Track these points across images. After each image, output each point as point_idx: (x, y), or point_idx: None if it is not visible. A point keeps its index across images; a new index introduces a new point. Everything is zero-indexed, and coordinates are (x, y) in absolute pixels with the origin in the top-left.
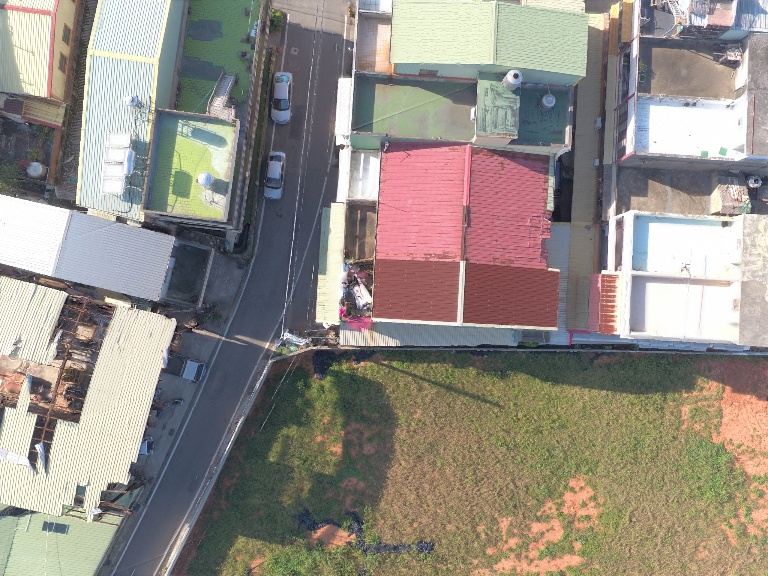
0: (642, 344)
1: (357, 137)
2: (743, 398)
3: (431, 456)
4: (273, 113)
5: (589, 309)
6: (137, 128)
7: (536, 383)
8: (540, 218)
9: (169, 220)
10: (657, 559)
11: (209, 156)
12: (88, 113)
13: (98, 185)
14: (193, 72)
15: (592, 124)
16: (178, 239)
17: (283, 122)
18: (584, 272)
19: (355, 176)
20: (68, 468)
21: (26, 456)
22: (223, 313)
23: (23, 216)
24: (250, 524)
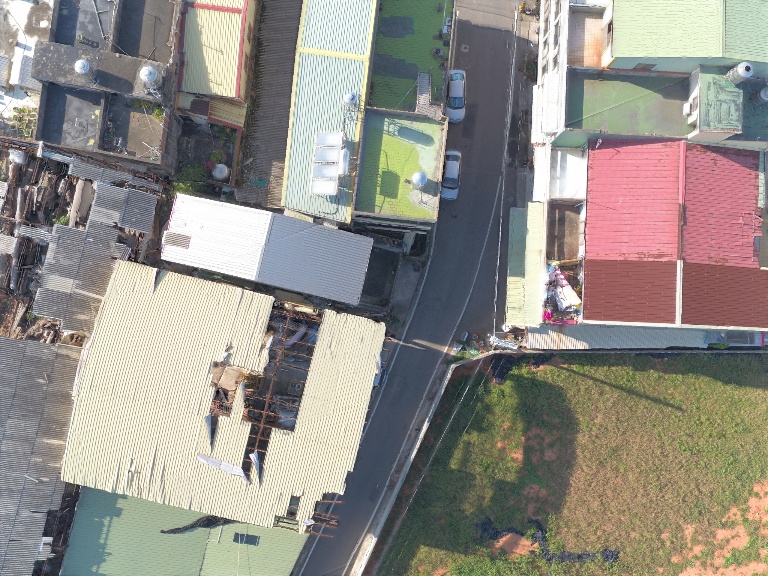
0: None
1: (567, 134)
2: None
3: (614, 462)
4: (447, 112)
5: None
6: (345, 127)
7: (718, 386)
8: (752, 215)
9: None
10: None
11: (416, 155)
12: (296, 112)
13: (304, 186)
14: (385, 70)
15: None
16: None
17: (457, 121)
18: None
19: (552, 174)
20: (282, 478)
21: (240, 466)
22: (400, 317)
23: (221, 219)
24: (432, 533)
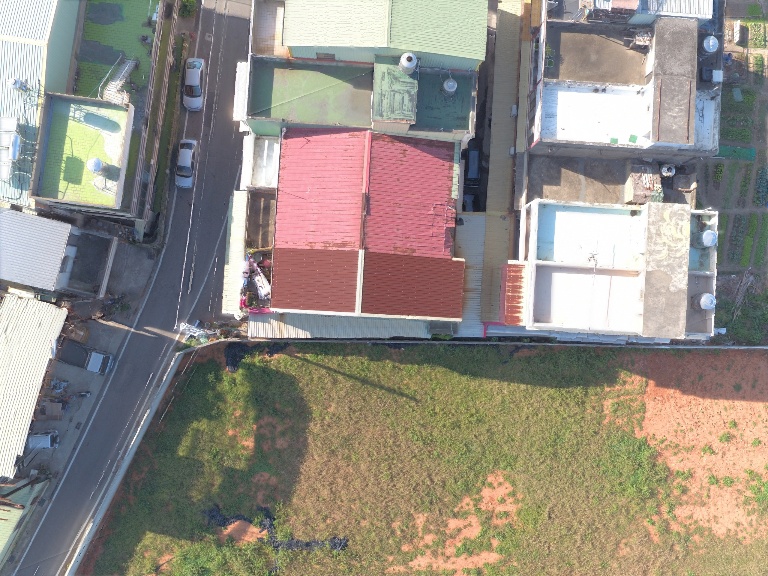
0: (556, 336)
1: (255, 122)
2: (667, 392)
3: (345, 451)
4: (185, 100)
5: (500, 300)
6: (26, 112)
7: (454, 376)
8: (444, 206)
9: (66, 208)
10: (577, 556)
11: (102, 141)
12: None
13: None
14: (93, 56)
15: (508, 112)
16: (79, 227)
17: (196, 109)
18: (499, 263)
19: (259, 163)
20: None
21: None
22: (132, 304)
23: None
24: (158, 520)
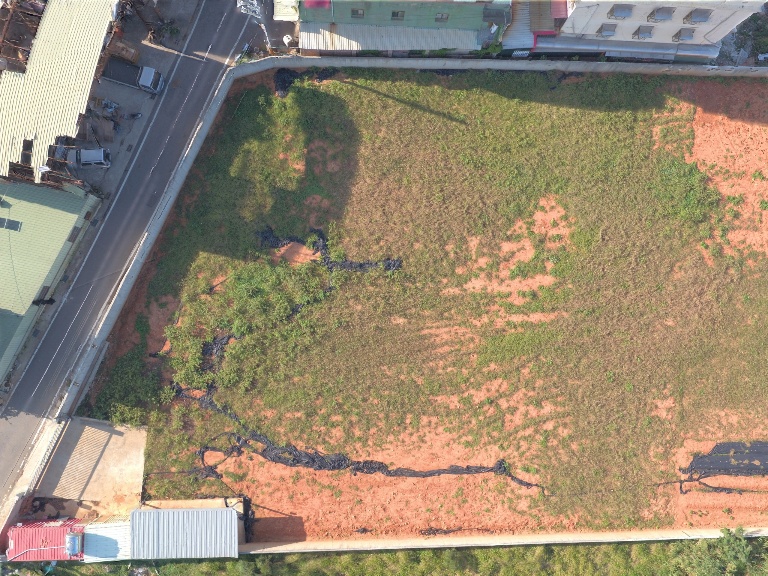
0: None
1: None
2: (715, 119)
3: (397, 173)
4: None
5: None
6: None
7: (503, 102)
8: None
9: None
10: (632, 278)
11: None
12: None
13: None
14: None
15: None
16: None
17: None
18: None
19: None
20: (14, 121)
21: None
22: (181, 30)
23: None
24: (211, 240)
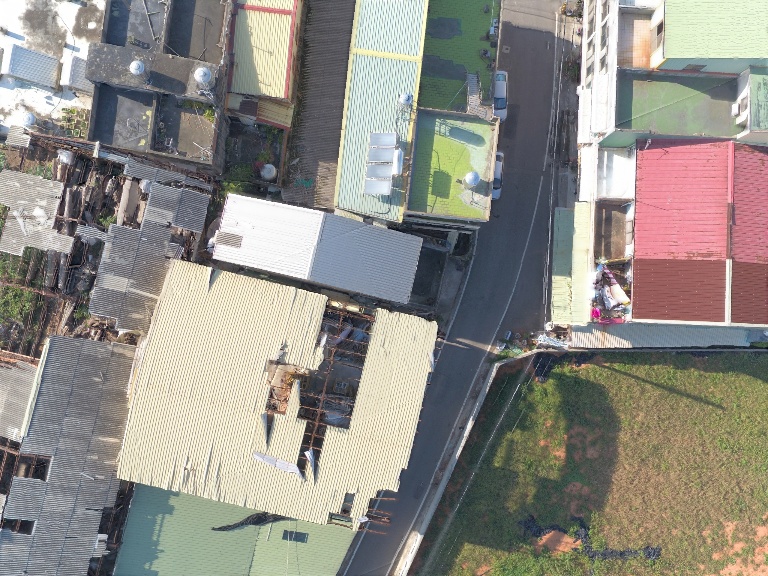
0: None
1: (616, 134)
2: None
3: (655, 460)
4: None
5: None
6: (398, 128)
7: (758, 384)
8: None
9: (416, 221)
10: None
11: (468, 155)
12: (349, 113)
13: (357, 186)
14: (433, 71)
15: None
16: None
17: None
18: None
19: (599, 174)
20: (337, 475)
21: (295, 463)
22: (444, 316)
23: (273, 219)
24: (476, 531)
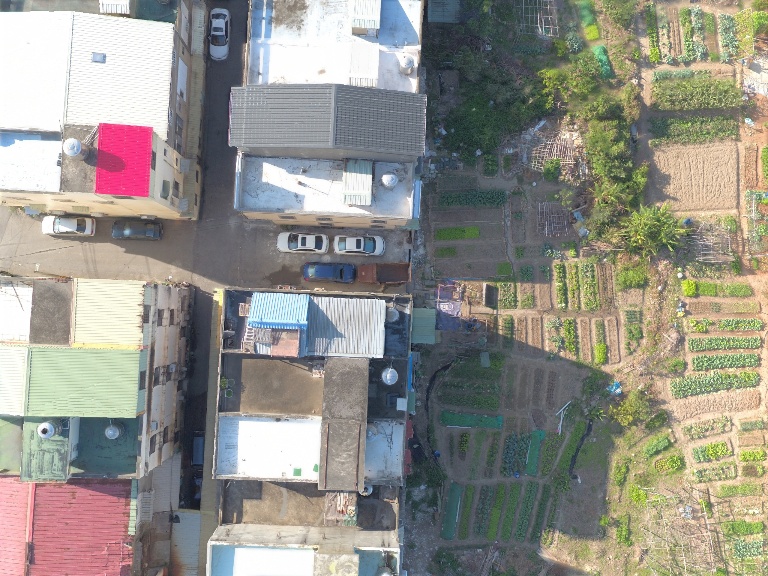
0: None
1: None
2: None
3: None
4: None
5: None
6: None
7: None
8: (120, 544)
9: None
10: None
11: None
12: None
13: None
14: None
15: None
16: None
17: None
18: None
19: None
20: None
21: None
22: None
23: None
24: None
